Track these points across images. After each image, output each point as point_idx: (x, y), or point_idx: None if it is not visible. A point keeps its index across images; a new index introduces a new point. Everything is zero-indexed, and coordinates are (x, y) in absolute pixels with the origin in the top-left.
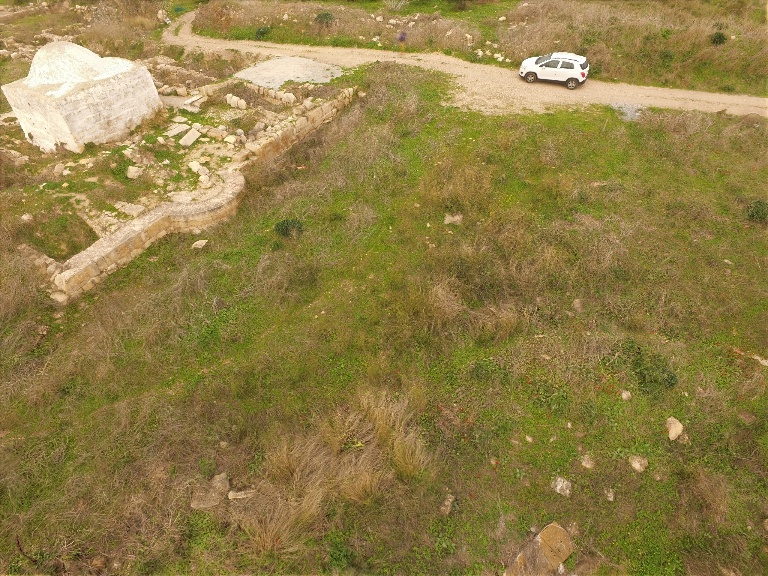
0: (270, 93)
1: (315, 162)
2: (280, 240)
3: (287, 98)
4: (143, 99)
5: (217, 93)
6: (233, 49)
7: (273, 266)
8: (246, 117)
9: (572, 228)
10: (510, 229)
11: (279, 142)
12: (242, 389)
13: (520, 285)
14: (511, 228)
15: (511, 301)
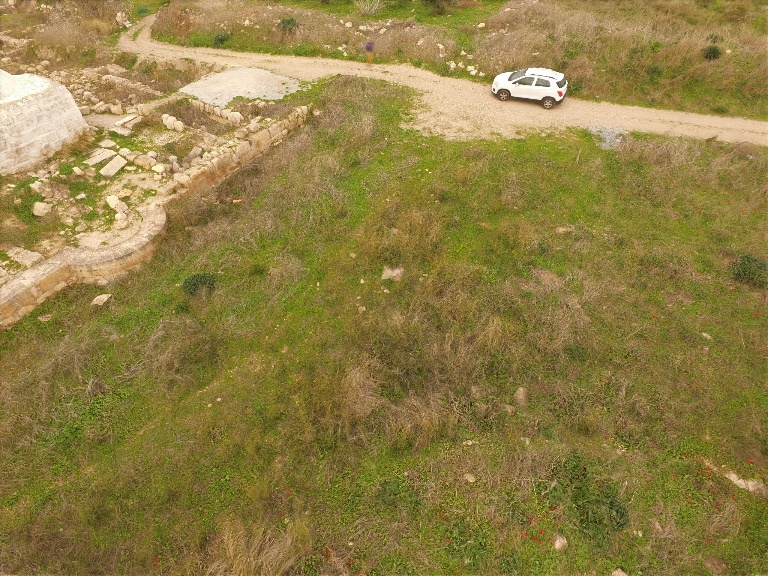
0: (215, 111)
1: (252, 195)
2: (187, 300)
3: (233, 117)
4: (62, 122)
5: (153, 113)
6: (187, 58)
7: (169, 337)
8: (182, 141)
9: (528, 287)
10: (453, 291)
11: (215, 171)
12: (93, 515)
13: (453, 370)
14: (454, 290)
15: (442, 389)
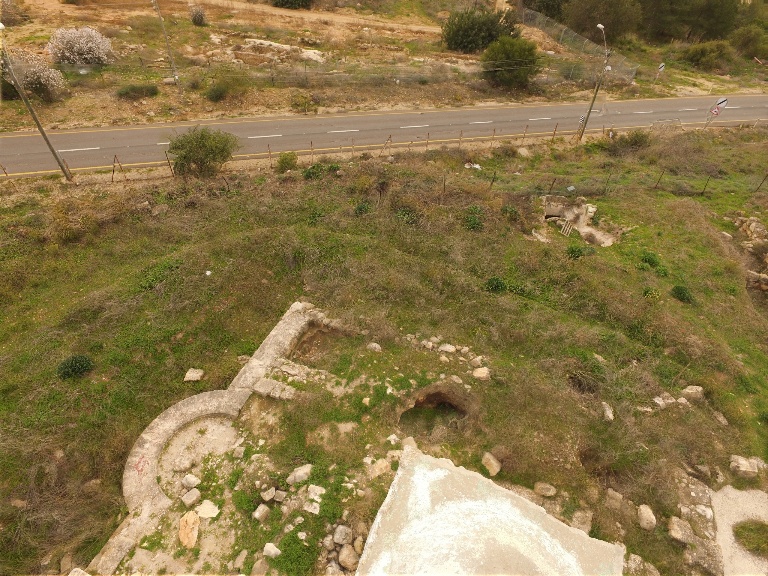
0: None
1: None
2: (91, 354)
3: None
4: None
5: None
6: None
7: None
8: None
9: None
10: None
11: None
12: None
13: None
14: None
15: None
